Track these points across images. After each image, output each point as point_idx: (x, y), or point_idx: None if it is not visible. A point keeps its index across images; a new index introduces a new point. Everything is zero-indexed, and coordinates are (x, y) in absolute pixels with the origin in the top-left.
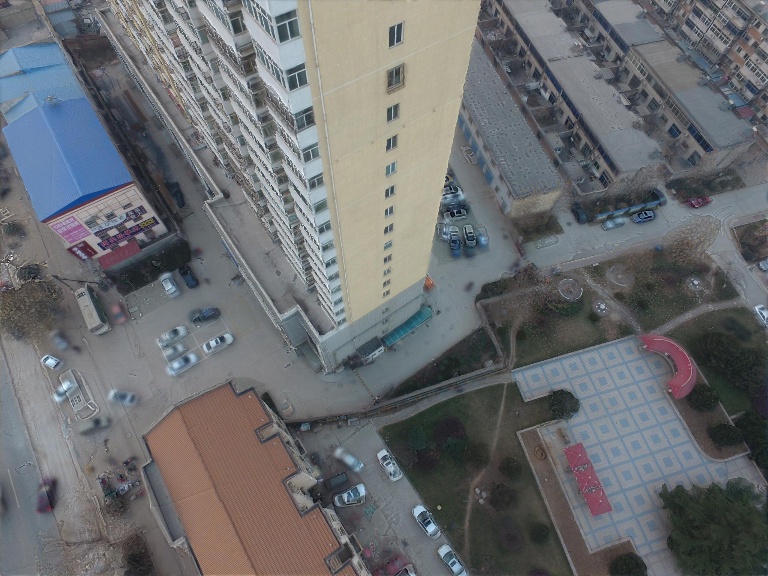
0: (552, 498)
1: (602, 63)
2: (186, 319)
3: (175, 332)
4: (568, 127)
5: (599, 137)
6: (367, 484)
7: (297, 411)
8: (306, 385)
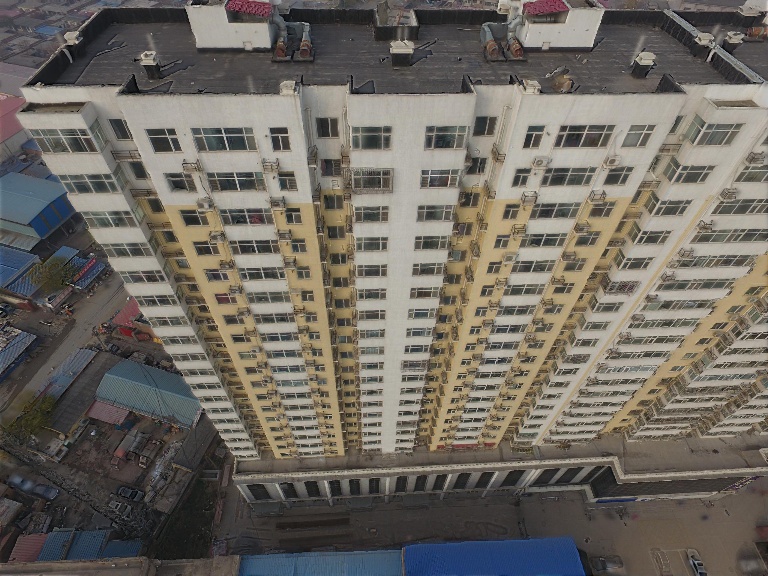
0: None
1: None
2: None
3: None
4: None
5: None
6: None
7: None
8: (749, 506)
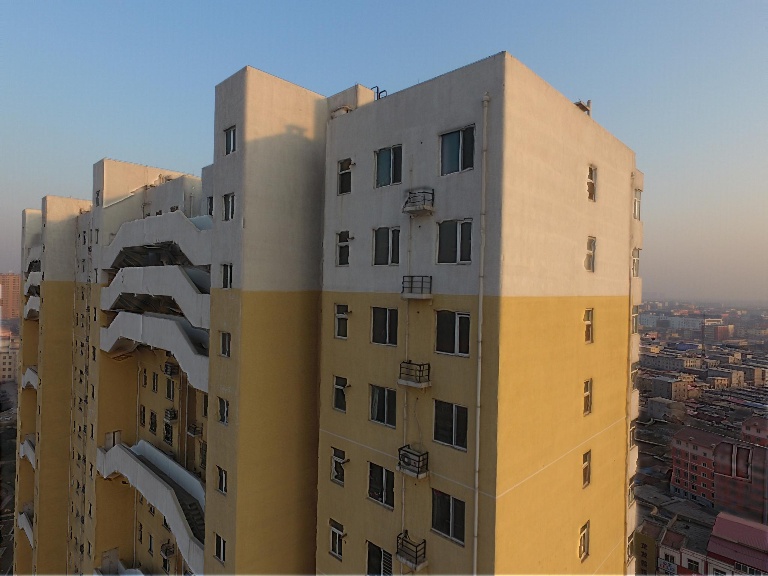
0: (7, 564)
1: None
2: None
3: None
4: None
5: None
6: None
7: None
8: None
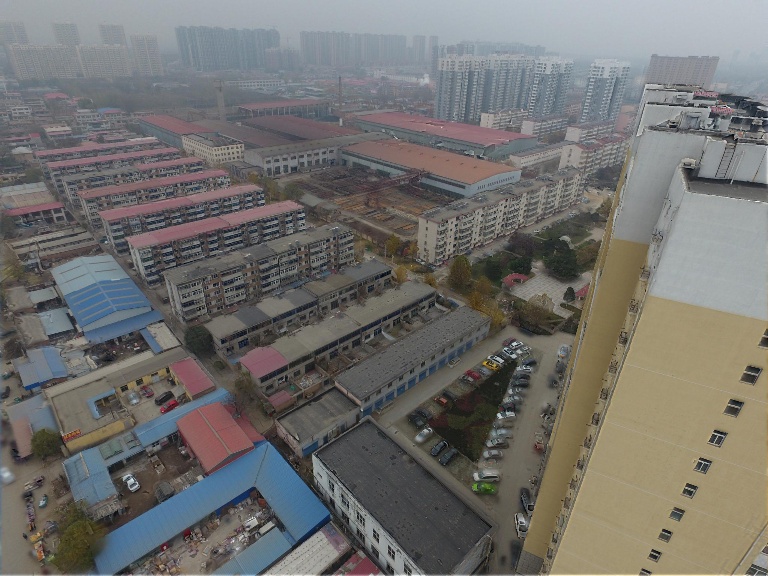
0: None
1: None
2: None
3: None
4: None
5: (418, 299)
6: None
7: None
8: None
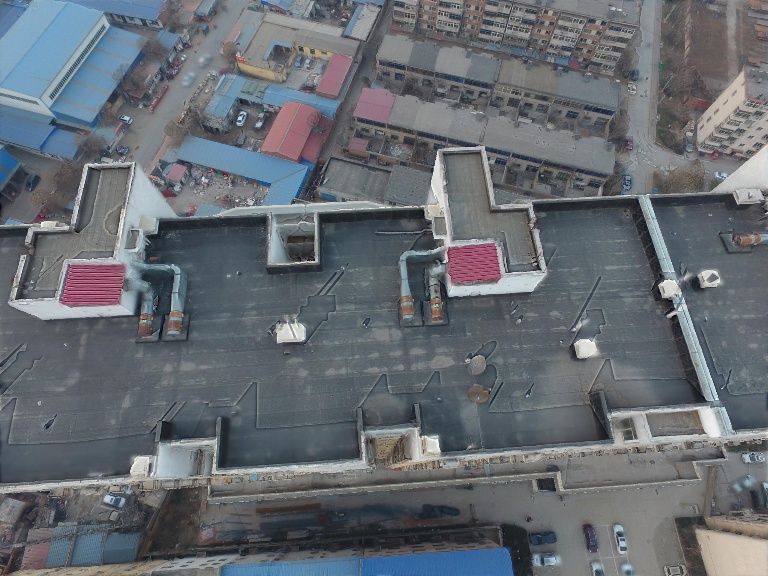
0: None
1: (472, 104)
2: (583, 558)
3: (598, 573)
4: (531, 171)
5: (575, 165)
6: (762, 480)
7: (696, 502)
8: None
